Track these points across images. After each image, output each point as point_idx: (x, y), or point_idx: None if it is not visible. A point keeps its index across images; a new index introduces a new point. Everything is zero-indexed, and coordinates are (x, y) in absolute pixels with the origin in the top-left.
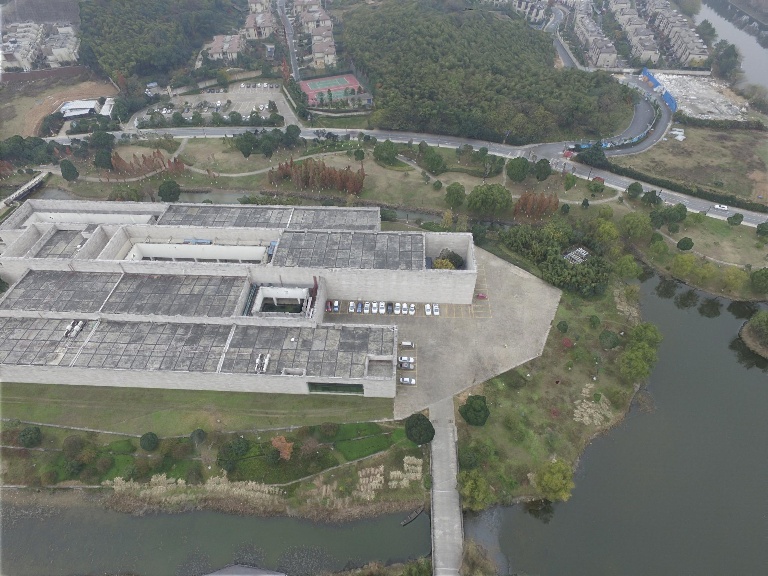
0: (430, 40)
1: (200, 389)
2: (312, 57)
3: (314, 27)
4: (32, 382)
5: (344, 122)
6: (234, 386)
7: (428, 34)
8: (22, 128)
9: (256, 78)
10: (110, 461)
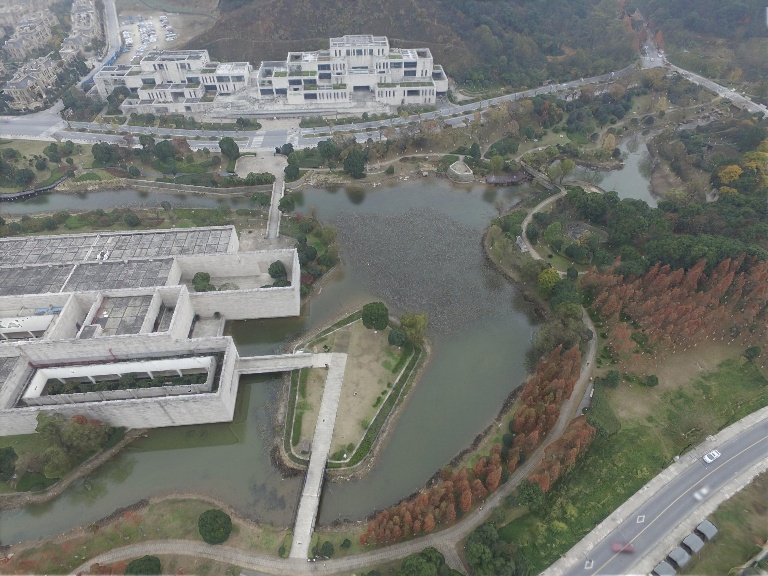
0: None
1: None
2: None
3: None
4: None
5: None
6: None
7: None
8: None
9: None
10: (79, 218)
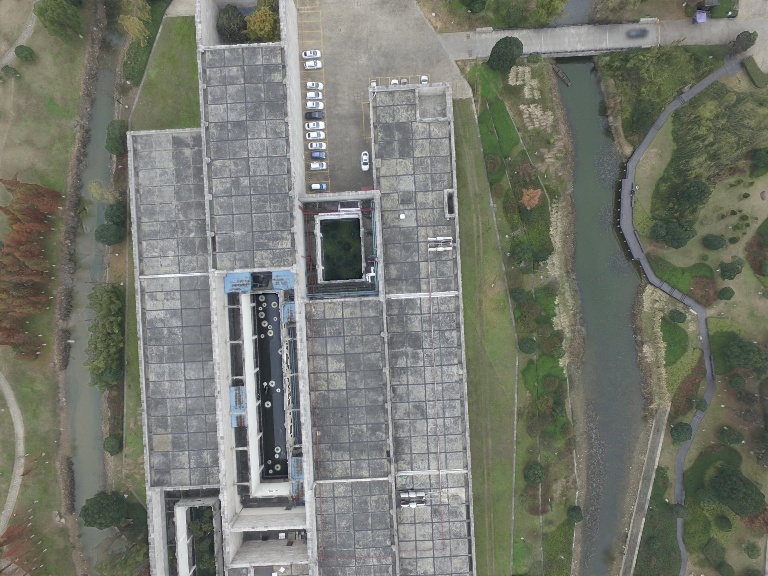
0: None
1: None
2: None
3: None
4: None
5: None
6: None
7: None
8: None
9: None
10: (548, 378)
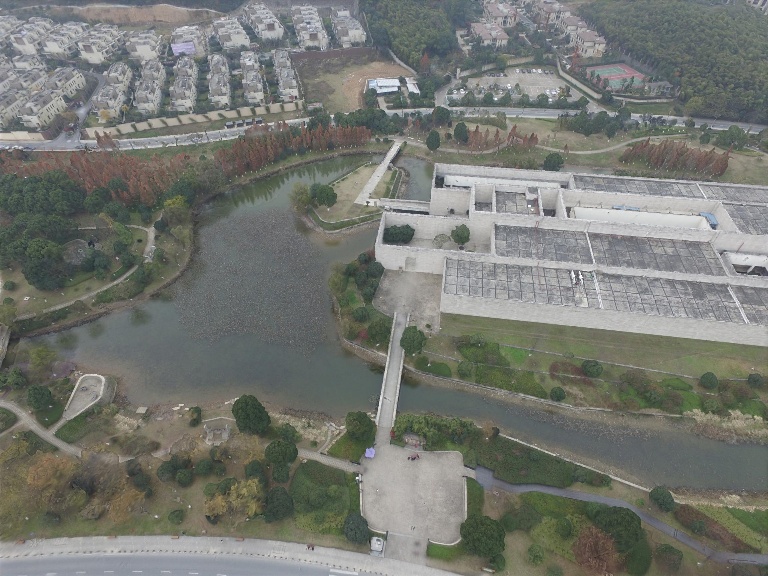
0: (721, 32)
1: (712, 340)
2: (572, 46)
3: (554, 18)
4: (547, 322)
5: (649, 108)
6: (752, 339)
7: (714, 26)
8: (347, 101)
9: (526, 64)
10: None
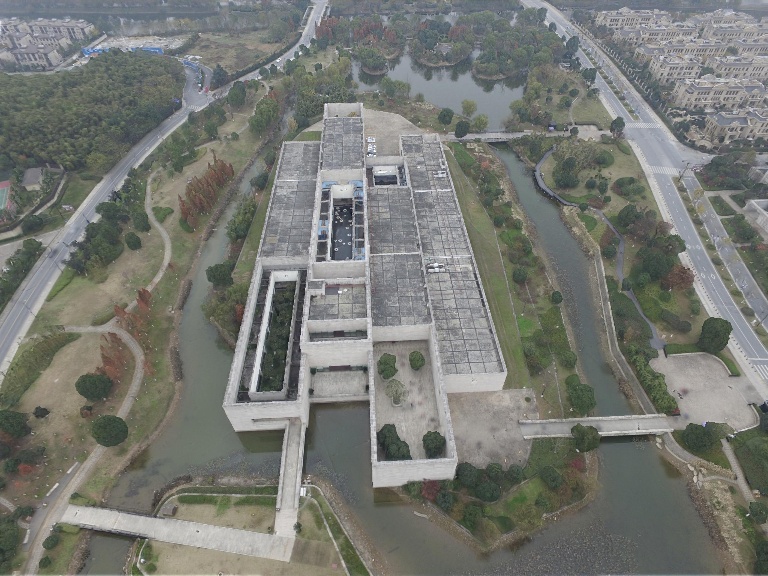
0: None
1: None
2: None
3: None
4: None
5: (73, 196)
6: None
7: None
8: None
9: None
10: None
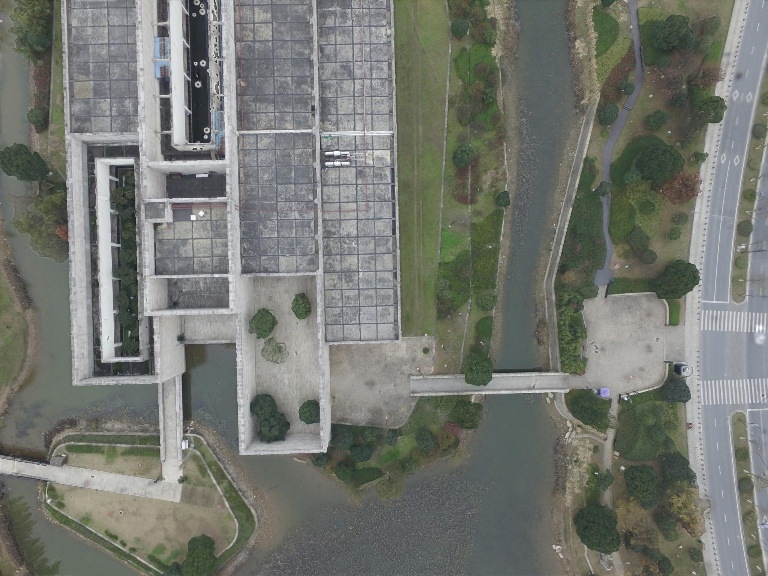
0: None
1: None
2: None
3: None
4: None
5: None
6: None
7: None
8: None
9: None
10: (479, 64)
